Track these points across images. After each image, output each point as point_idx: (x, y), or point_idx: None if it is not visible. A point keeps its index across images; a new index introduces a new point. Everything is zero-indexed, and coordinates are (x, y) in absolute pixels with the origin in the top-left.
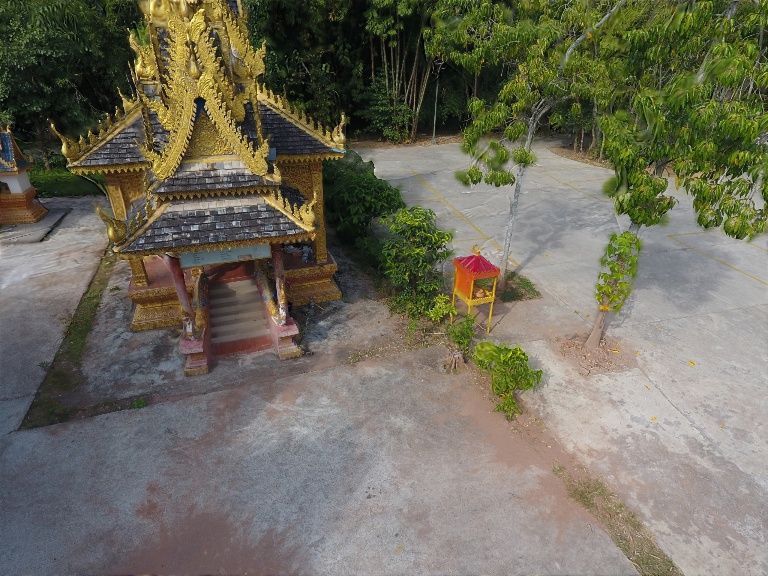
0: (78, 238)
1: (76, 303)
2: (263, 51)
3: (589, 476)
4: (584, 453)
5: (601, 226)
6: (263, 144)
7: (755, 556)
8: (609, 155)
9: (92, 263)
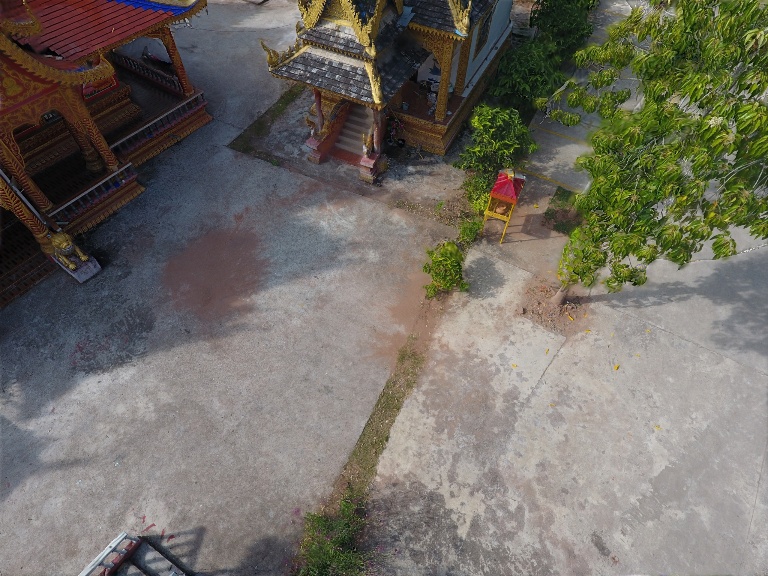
0: None
1: None
2: None
3: (423, 353)
4: (440, 343)
5: None
6: (368, 23)
7: (444, 445)
8: None
9: None
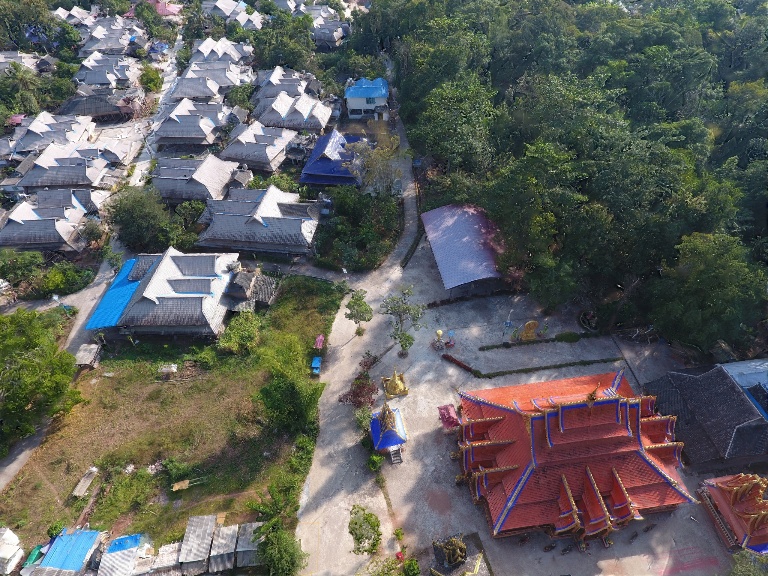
0: None
1: None
2: None
3: None
4: None
5: None
6: None
7: None
8: None
9: None
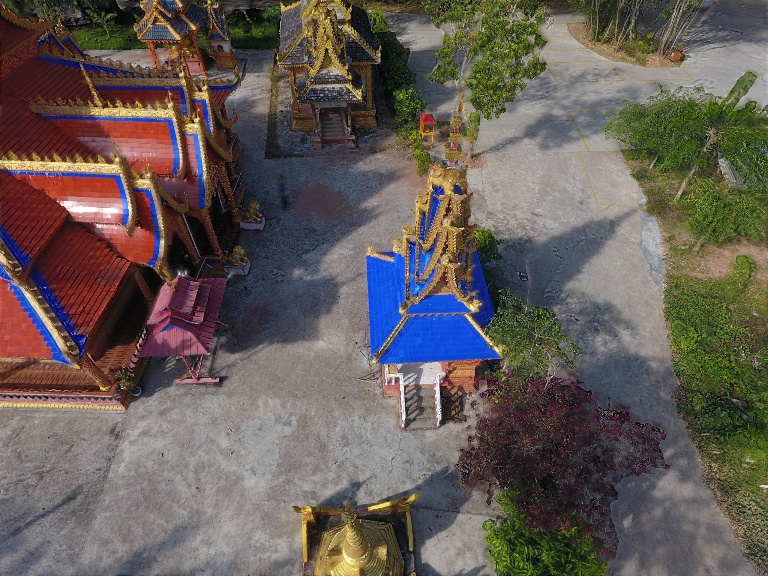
0: (256, 80)
1: (267, 116)
2: (351, 10)
3: None
4: None
5: (535, 101)
6: (346, 65)
7: None
8: (601, 39)
9: (267, 96)
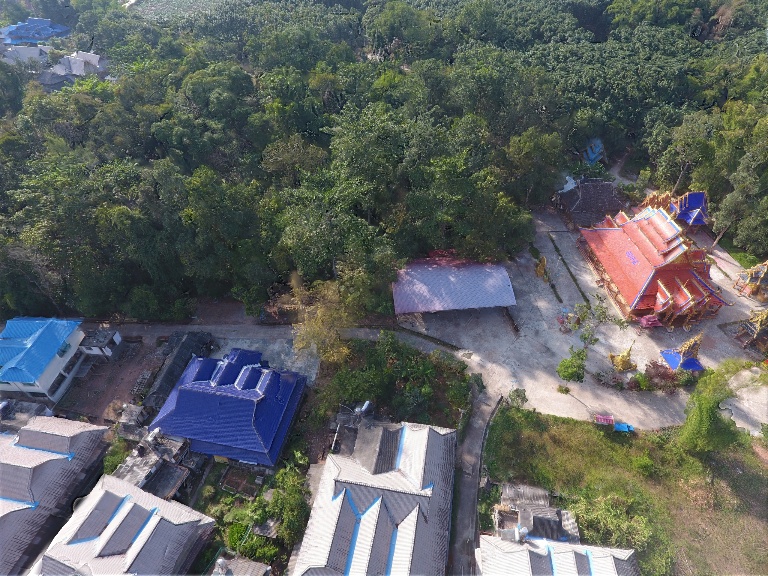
0: None
1: None
2: None
3: None
4: None
5: None
6: None
7: None
8: None
9: None
